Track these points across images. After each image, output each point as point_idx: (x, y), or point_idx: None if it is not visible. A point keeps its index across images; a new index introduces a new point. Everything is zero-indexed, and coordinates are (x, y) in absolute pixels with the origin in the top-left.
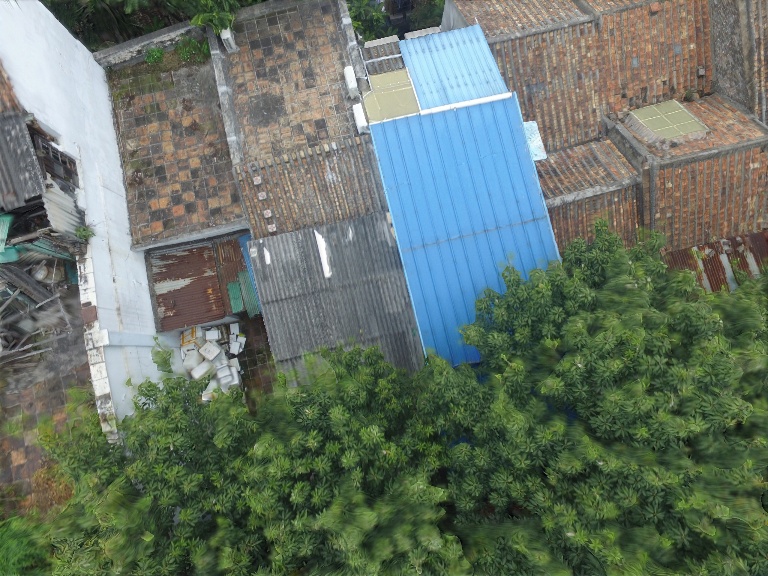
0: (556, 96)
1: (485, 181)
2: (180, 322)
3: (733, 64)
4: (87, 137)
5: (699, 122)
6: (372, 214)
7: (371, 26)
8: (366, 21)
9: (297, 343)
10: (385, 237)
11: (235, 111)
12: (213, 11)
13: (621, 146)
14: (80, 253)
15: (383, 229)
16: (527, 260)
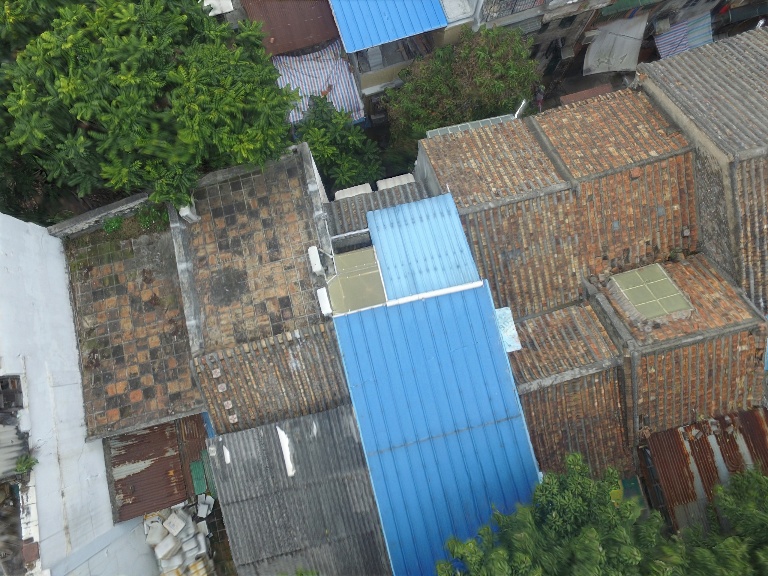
0: (533, 262)
1: (455, 377)
2: (139, 510)
3: (719, 232)
4: (36, 337)
5: (683, 297)
6: (337, 408)
7: (347, 148)
8: (342, 144)
9: (259, 546)
10: (351, 432)
11: (195, 288)
12: (170, 193)
13: (602, 318)
14: (22, 482)
15: (349, 424)
16: (501, 462)
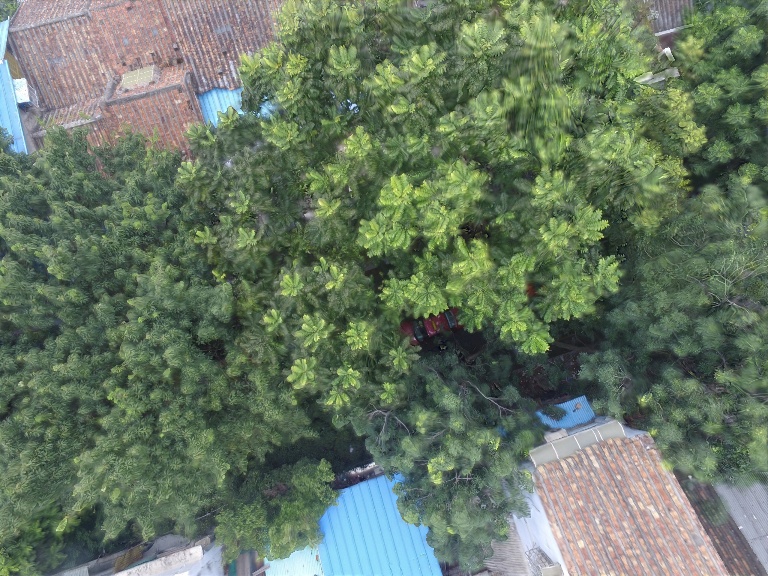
0: (72, 65)
1: None
2: None
3: None
4: None
5: None
6: None
7: None
8: None
9: None
10: None
11: None
12: None
13: None
14: None
15: None
16: None
